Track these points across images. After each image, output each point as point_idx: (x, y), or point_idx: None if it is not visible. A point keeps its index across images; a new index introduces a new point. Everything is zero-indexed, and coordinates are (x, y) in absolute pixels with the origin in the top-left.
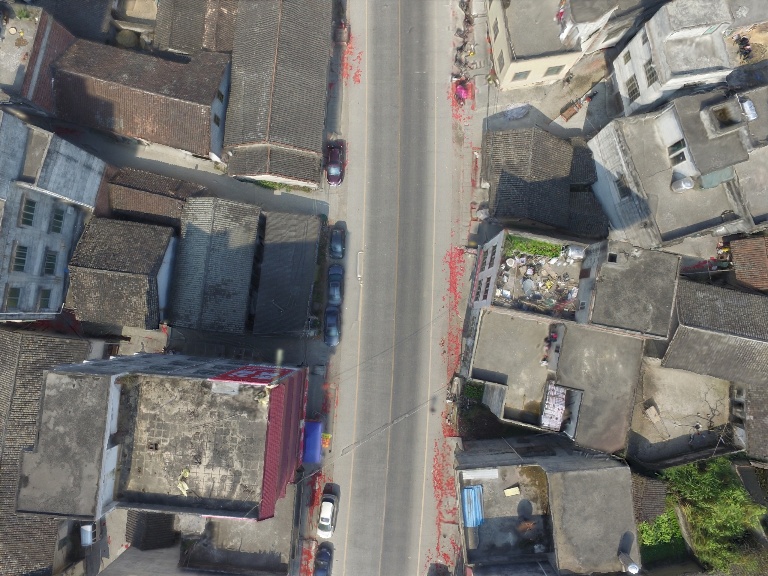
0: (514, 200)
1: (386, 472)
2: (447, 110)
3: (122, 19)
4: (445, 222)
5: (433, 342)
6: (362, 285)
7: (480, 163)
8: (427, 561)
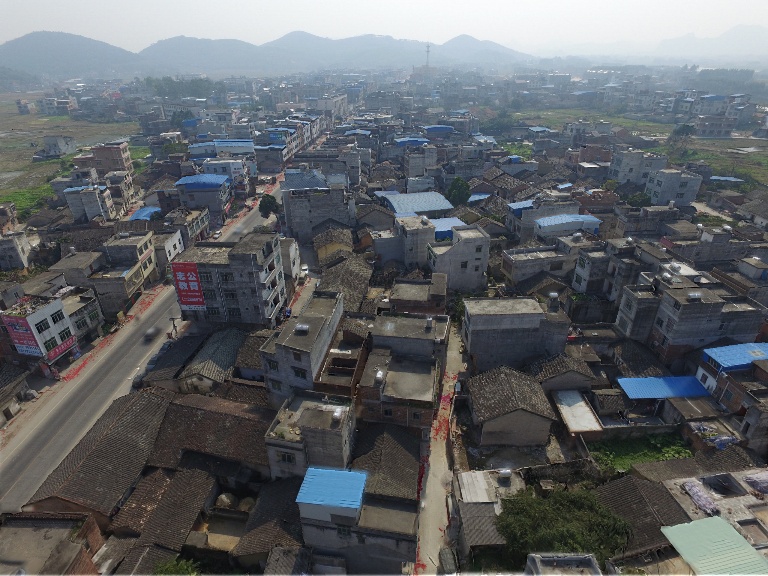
0: (6, 373)
1: (172, 306)
2: (0, 456)
3: (240, 513)
4: (62, 392)
5: (114, 344)
6: (139, 365)
7: (8, 424)
8: (171, 286)
